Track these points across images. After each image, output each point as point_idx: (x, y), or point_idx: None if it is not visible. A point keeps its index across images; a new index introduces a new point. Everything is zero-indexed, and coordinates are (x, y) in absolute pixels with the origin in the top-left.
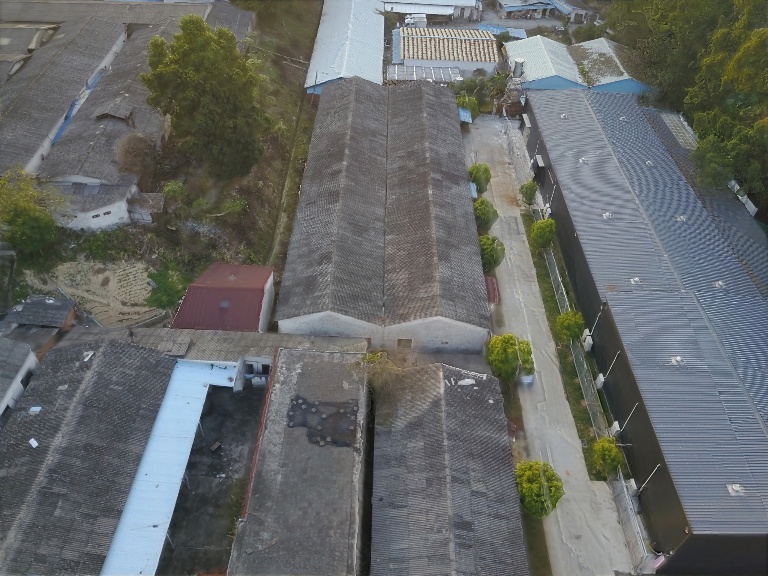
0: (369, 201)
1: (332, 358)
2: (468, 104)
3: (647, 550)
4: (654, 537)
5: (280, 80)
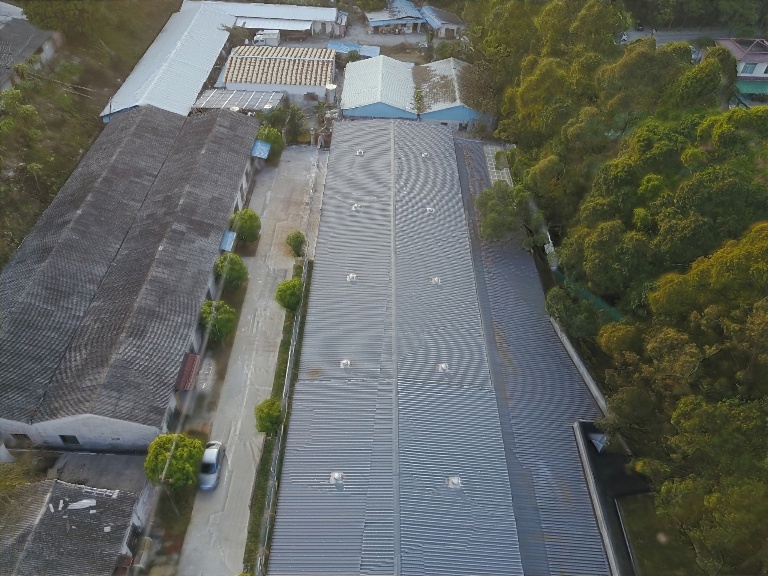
0: (90, 259)
1: None
2: (267, 136)
3: None
4: None
5: (73, 108)
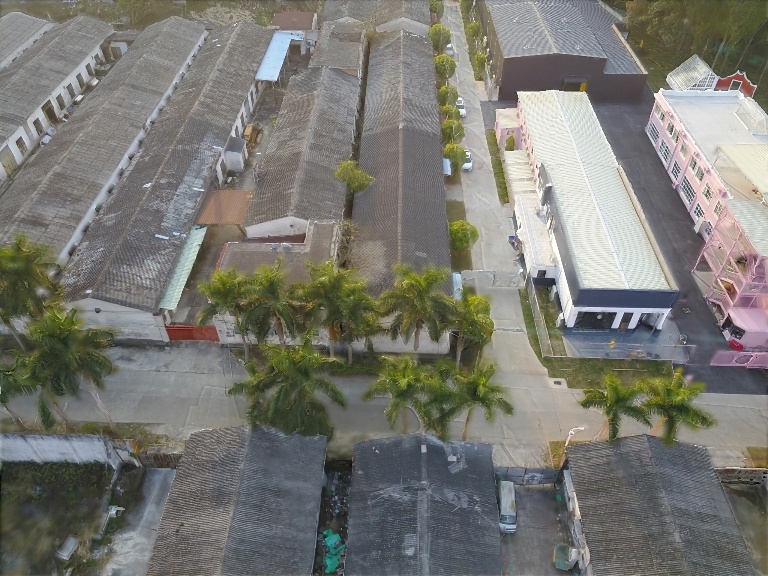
0: None
1: (349, 23)
2: None
3: (492, 85)
4: None
5: None
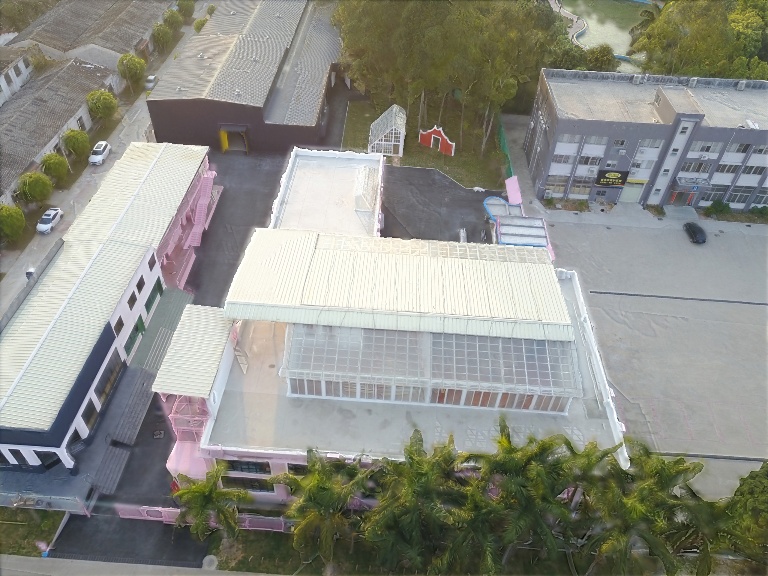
0: (95, 6)
1: (12, 48)
2: None
3: (147, 128)
4: None
5: None
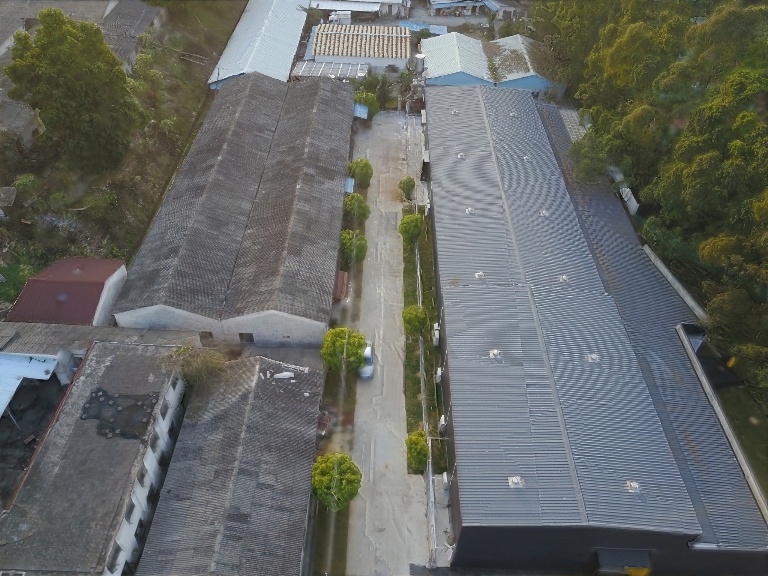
0: (237, 196)
1: (146, 351)
2: (365, 100)
3: (437, 543)
4: (453, 530)
5: (183, 76)
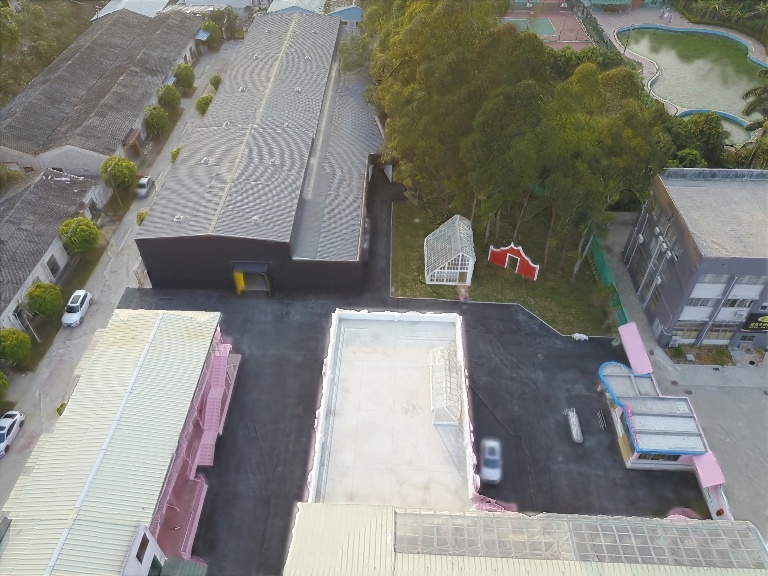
0: (75, 86)
1: None
2: (207, 27)
3: (139, 268)
4: None
5: (71, 16)
